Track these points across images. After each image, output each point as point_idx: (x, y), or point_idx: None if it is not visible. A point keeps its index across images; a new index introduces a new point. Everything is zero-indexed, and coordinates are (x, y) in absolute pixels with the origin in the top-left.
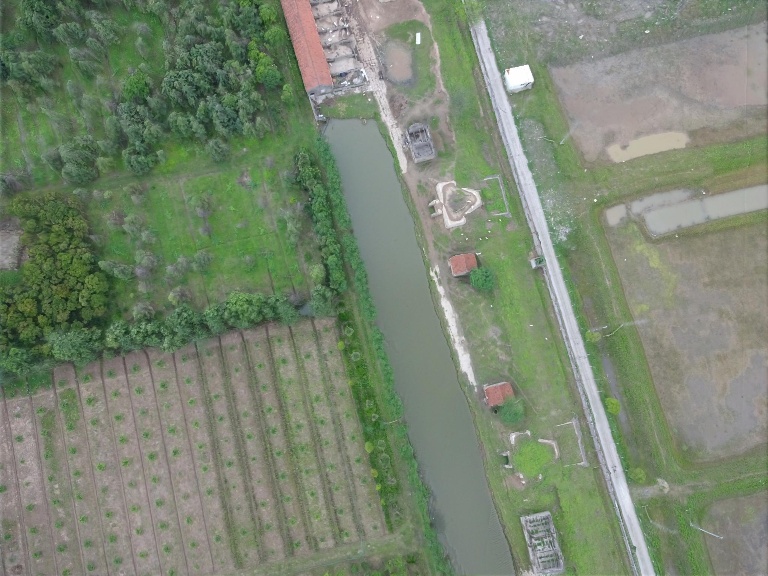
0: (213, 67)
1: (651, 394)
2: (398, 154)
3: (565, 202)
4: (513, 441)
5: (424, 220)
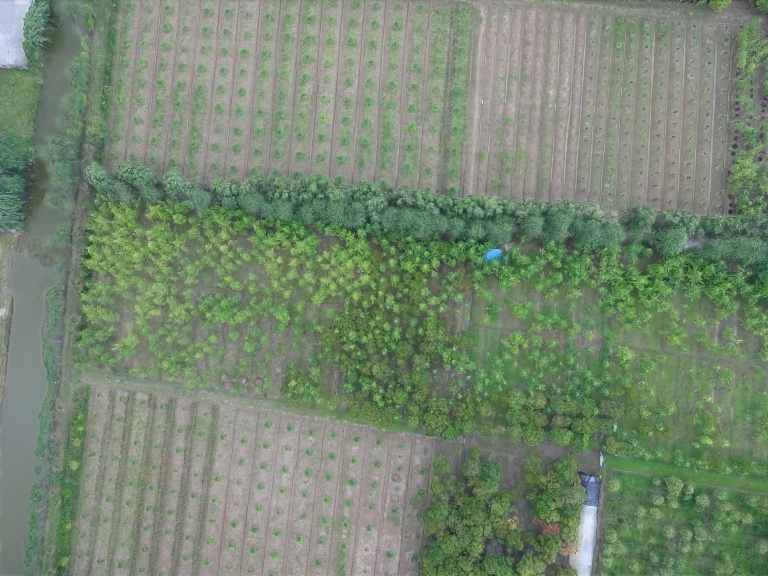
0: None
1: None
2: None
3: None
4: None
5: None
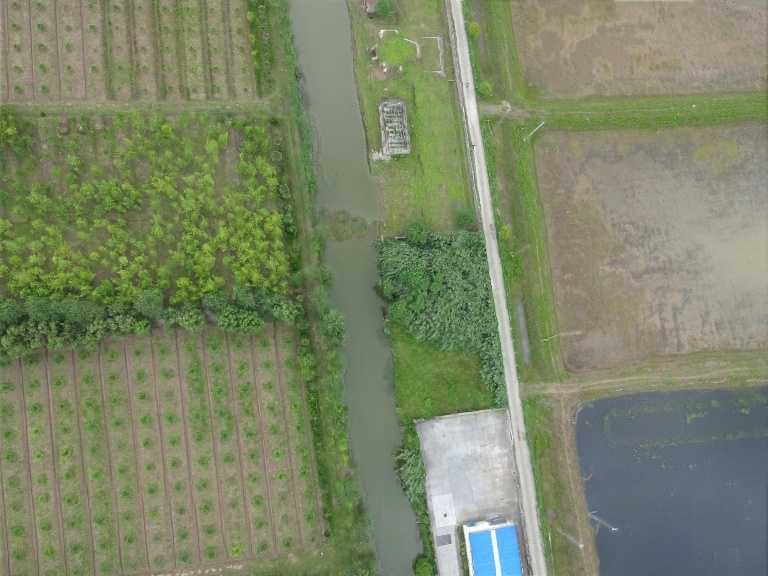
0: None
1: (509, 33)
2: None
3: None
4: (382, 35)
5: None
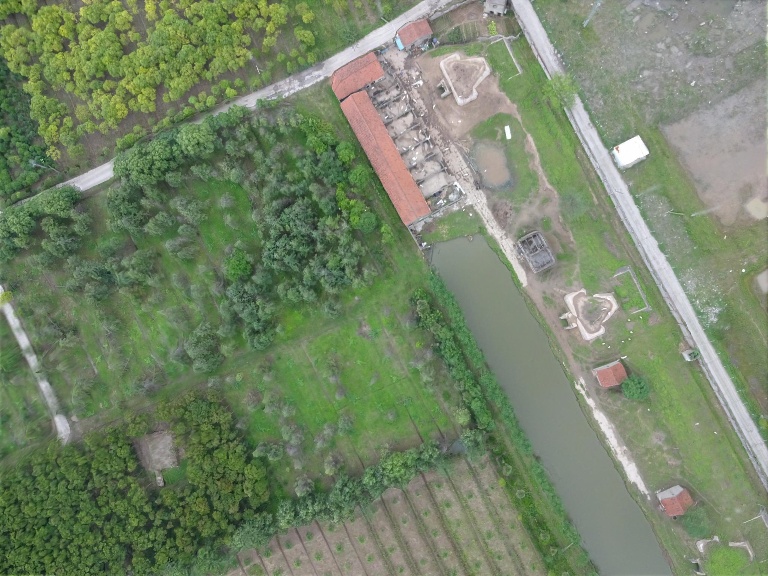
0: (307, 228)
1: None
2: (514, 267)
3: (709, 280)
4: (702, 550)
5: (557, 333)
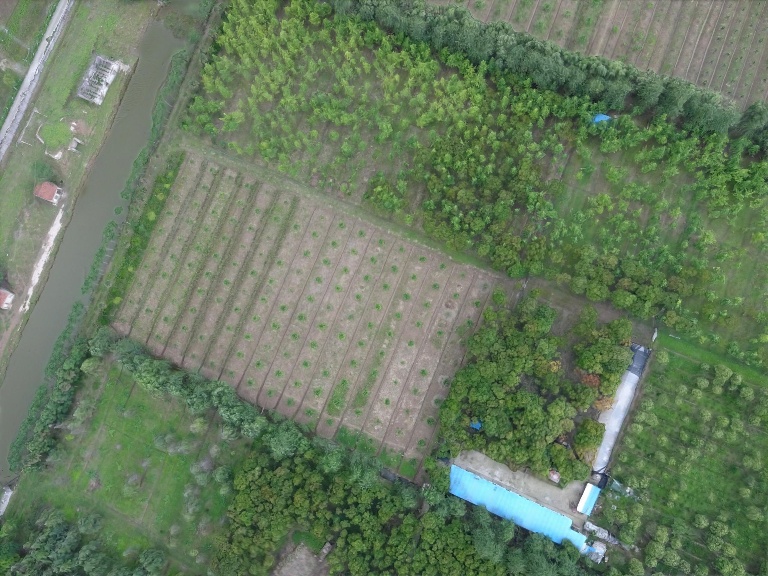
0: None
1: None
2: None
3: None
4: (59, 154)
5: (1, 351)
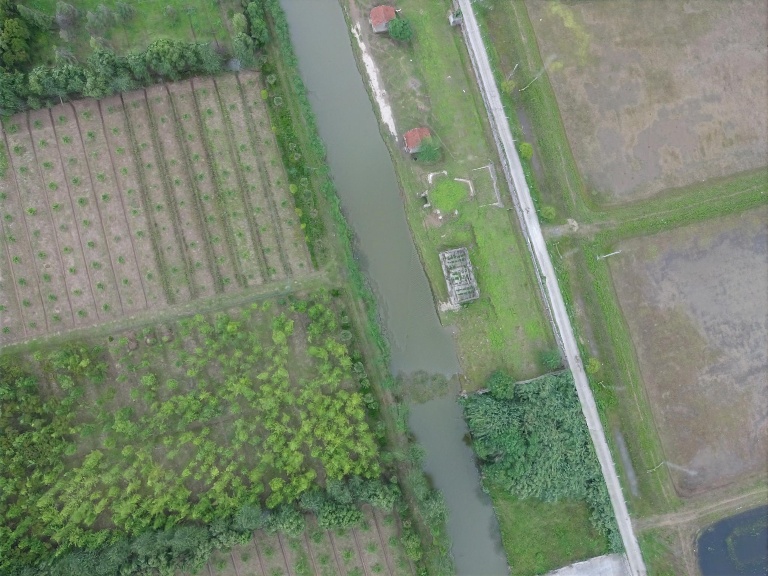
0: None
1: (563, 142)
2: None
3: None
4: (430, 180)
5: None
